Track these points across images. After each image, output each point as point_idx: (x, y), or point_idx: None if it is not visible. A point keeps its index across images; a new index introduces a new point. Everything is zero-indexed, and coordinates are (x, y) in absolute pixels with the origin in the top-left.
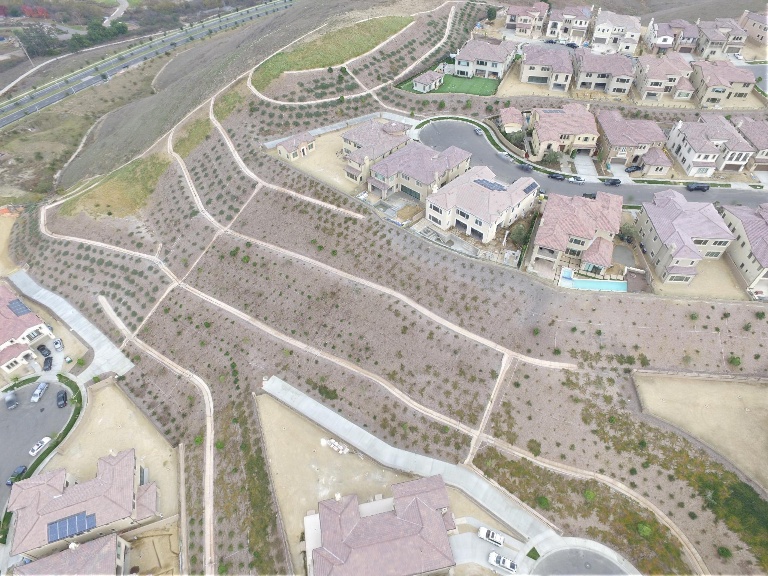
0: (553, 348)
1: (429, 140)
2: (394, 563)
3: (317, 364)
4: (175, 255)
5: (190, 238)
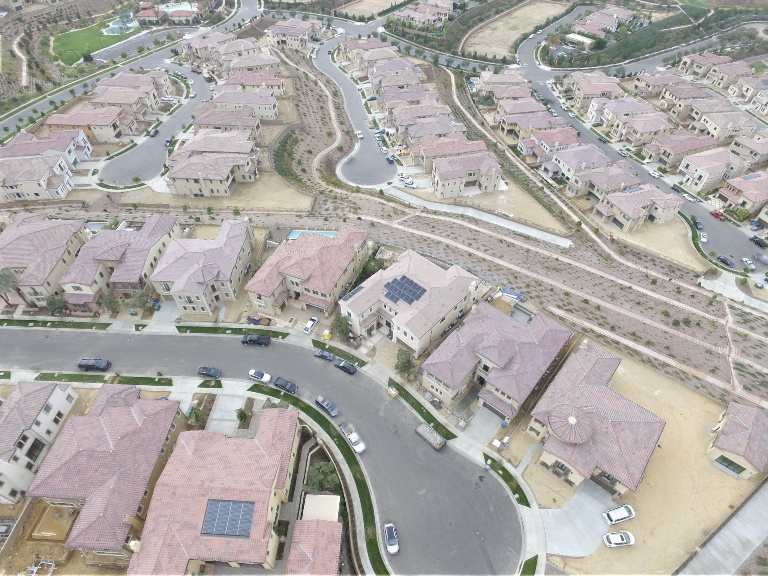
0: (362, 220)
1: (497, 503)
2: (461, 156)
3: (537, 244)
4: (766, 346)
5: (767, 354)
